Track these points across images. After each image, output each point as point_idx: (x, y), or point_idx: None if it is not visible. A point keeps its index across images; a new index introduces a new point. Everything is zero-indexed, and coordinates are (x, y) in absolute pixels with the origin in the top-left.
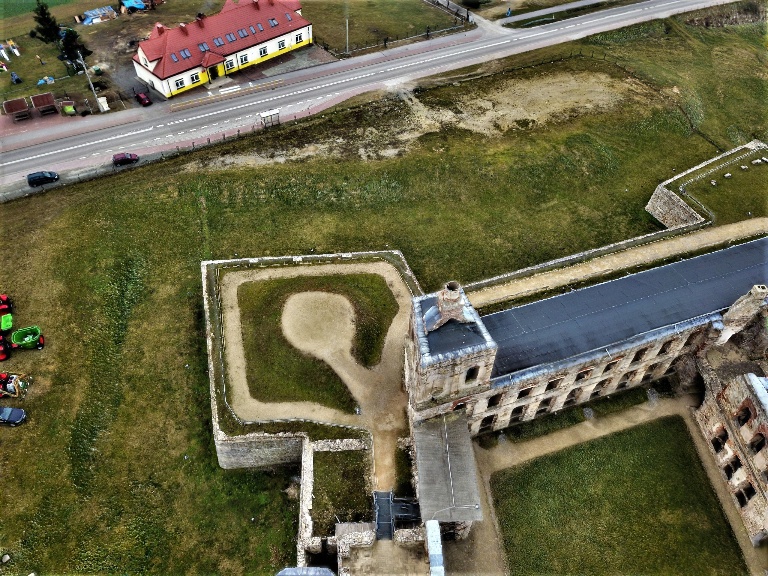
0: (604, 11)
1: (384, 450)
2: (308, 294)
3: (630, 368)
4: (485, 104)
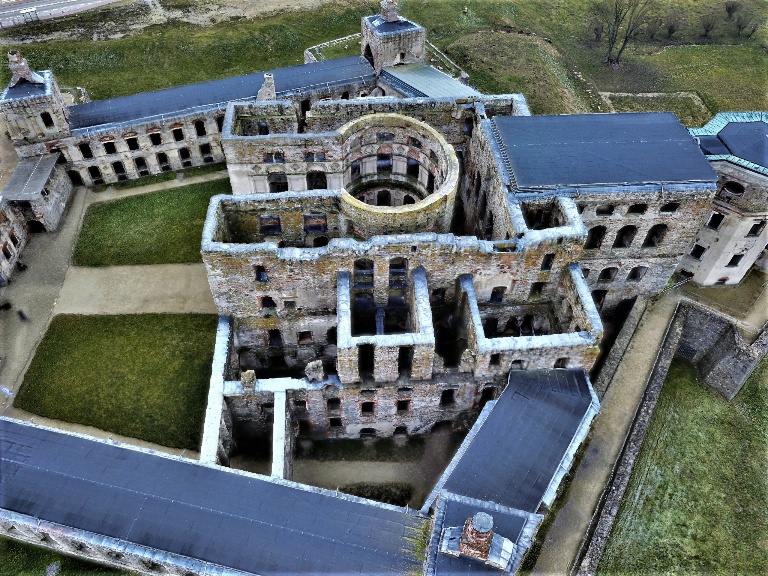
0: None
1: (7, 181)
2: None
3: (200, 140)
4: (212, 7)
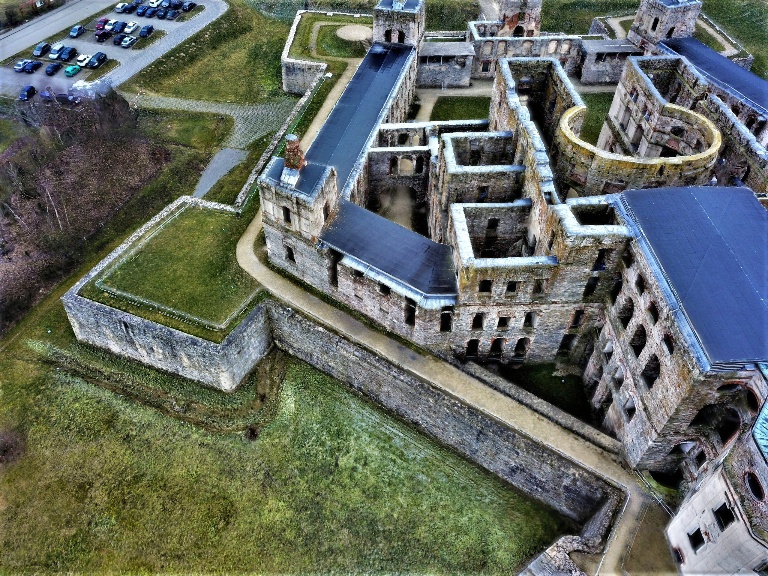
0: None
1: None
2: None
3: None
4: None
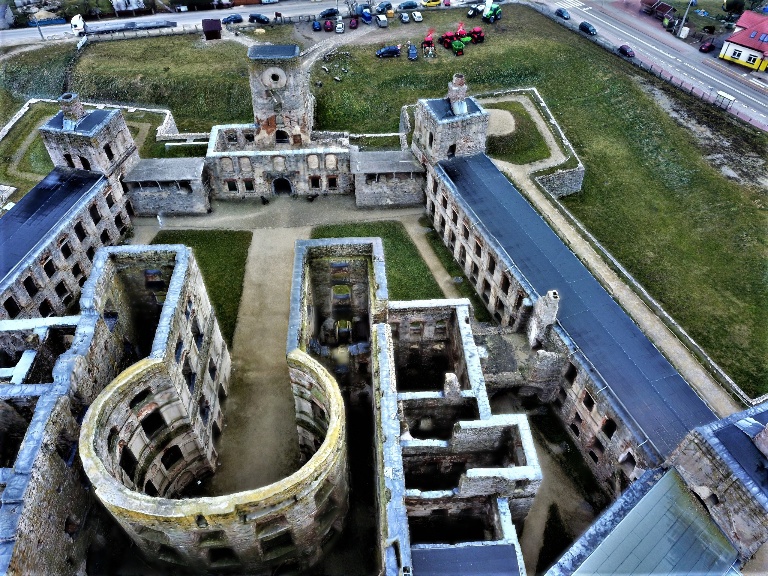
0: None
1: None
2: (511, 117)
3: None
4: None
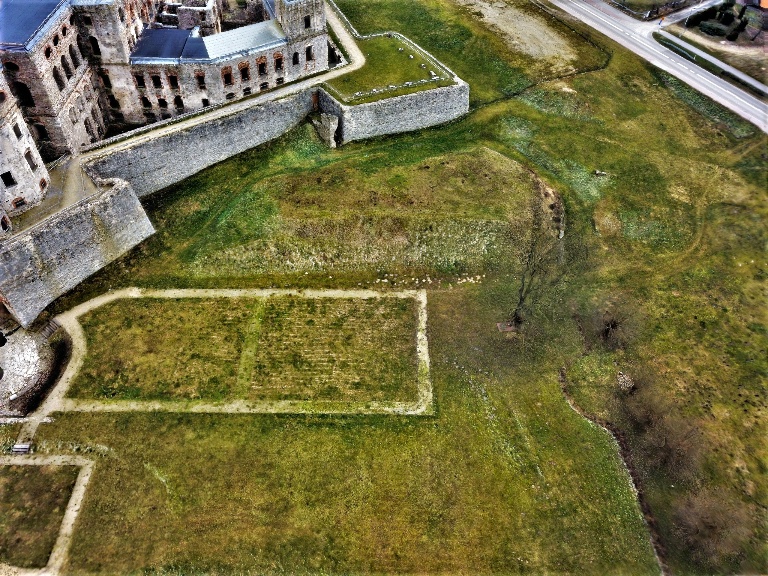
0: (747, 94)
1: None
2: None
3: None
4: (499, 4)
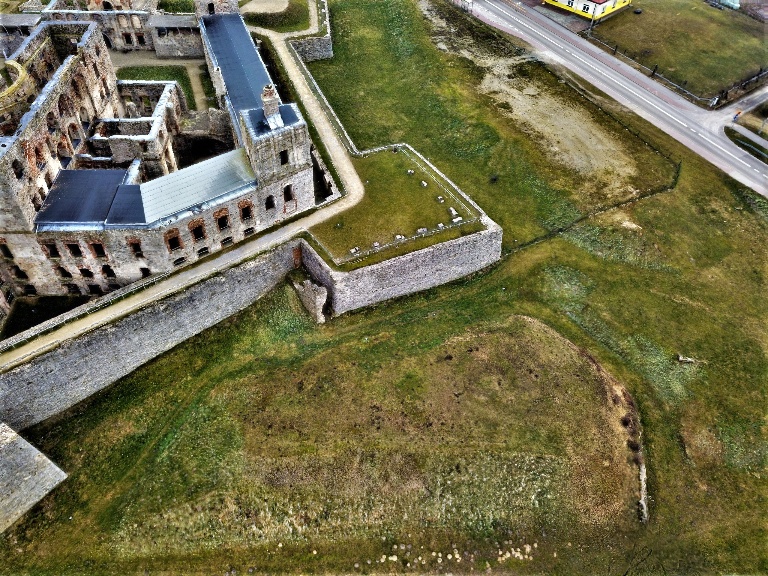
0: None
1: None
2: (287, 3)
3: None
4: (530, 91)
